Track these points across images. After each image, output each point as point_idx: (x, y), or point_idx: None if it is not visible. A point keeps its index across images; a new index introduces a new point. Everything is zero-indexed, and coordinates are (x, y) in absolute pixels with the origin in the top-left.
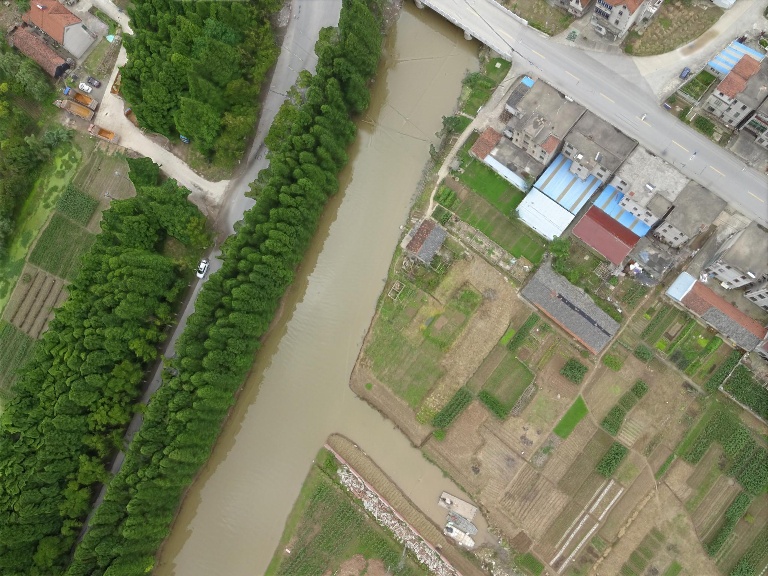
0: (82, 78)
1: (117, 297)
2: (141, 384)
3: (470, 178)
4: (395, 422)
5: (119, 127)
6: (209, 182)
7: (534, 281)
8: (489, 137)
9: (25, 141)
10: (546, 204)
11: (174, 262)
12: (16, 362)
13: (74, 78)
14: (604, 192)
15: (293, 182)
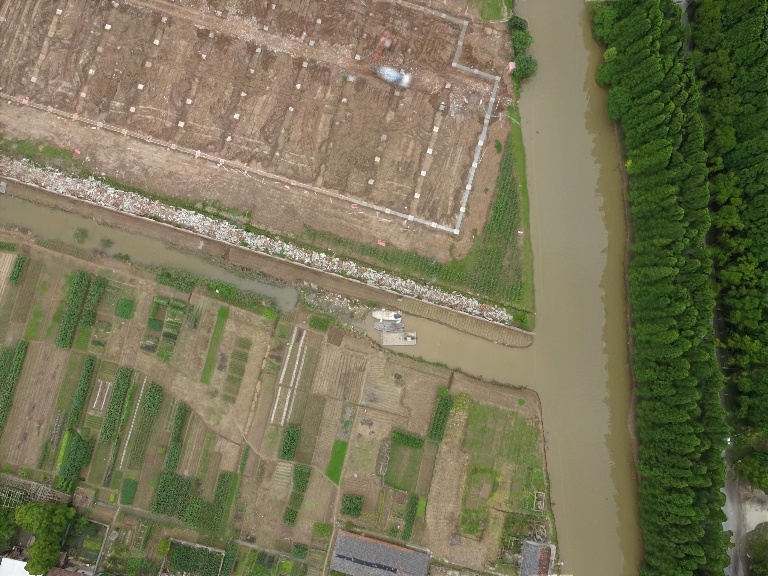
0: None
1: None
2: (724, 308)
3: None
4: (484, 382)
5: None
6: (766, 521)
7: (423, 574)
8: None
9: None
10: None
11: (760, 433)
12: None
13: None
14: None
15: (695, 569)
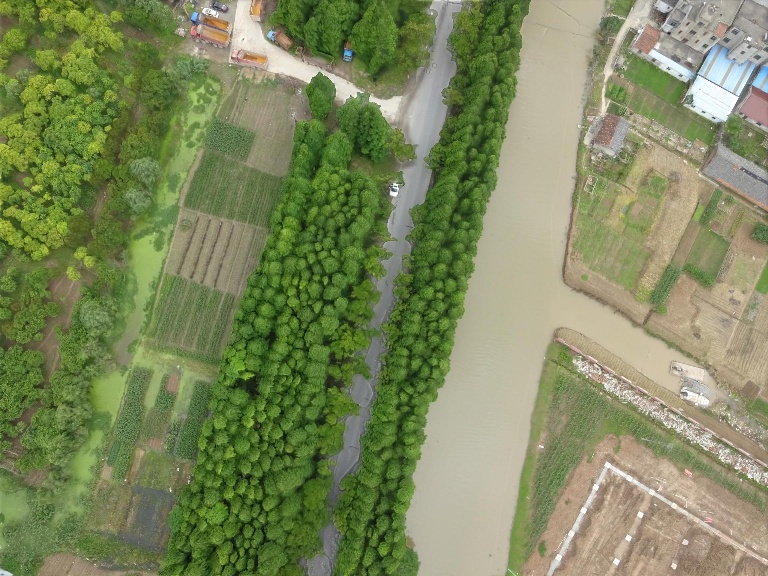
0: (202, 3)
1: (351, 213)
2: None
3: (634, 74)
4: (616, 306)
5: (262, 52)
6: (380, 100)
7: (717, 158)
8: (651, 32)
9: (164, 71)
10: (712, 89)
11: (379, 179)
12: (196, 316)
13: (194, 3)
14: (760, 73)
15: (495, 84)
